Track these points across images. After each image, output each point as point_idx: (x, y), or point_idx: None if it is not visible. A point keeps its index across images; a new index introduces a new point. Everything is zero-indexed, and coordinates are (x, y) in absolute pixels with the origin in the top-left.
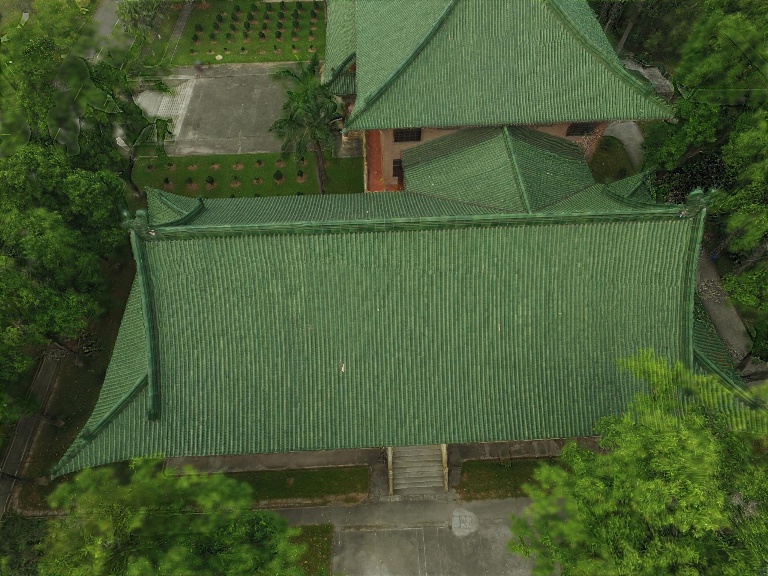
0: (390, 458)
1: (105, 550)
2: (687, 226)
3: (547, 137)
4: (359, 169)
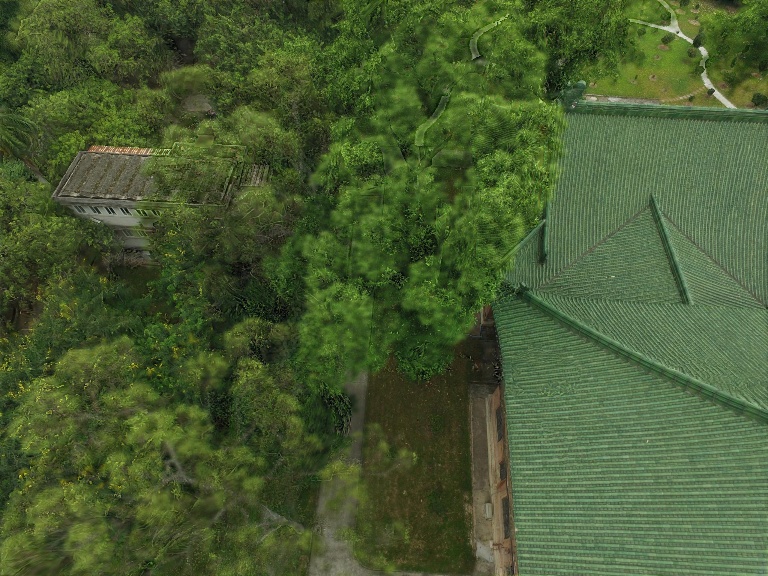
0: None
1: None
2: None
3: None
4: None
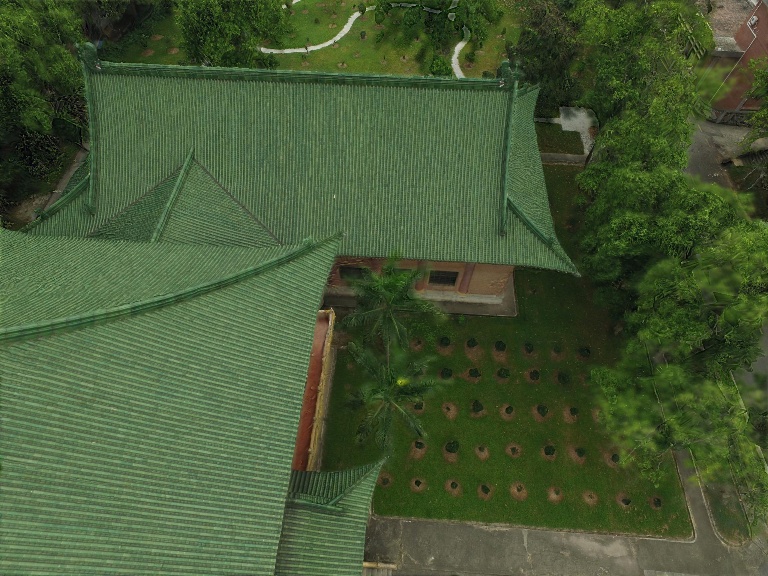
0: None
1: None
2: None
3: None
4: (334, 459)
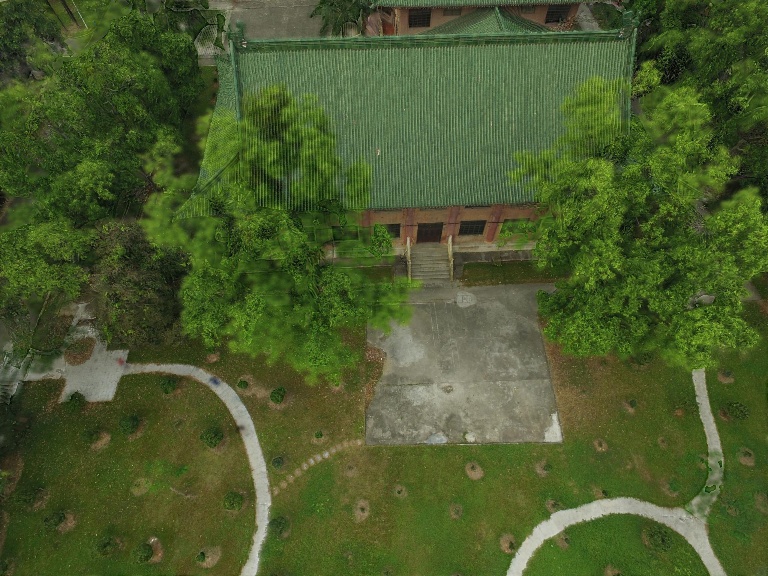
0: (409, 254)
1: (245, 186)
2: (625, 46)
3: (530, 22)
4: None
